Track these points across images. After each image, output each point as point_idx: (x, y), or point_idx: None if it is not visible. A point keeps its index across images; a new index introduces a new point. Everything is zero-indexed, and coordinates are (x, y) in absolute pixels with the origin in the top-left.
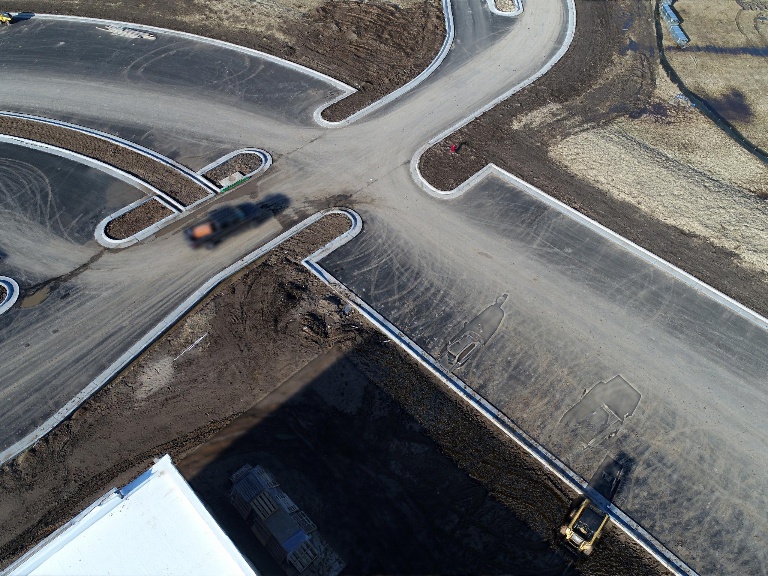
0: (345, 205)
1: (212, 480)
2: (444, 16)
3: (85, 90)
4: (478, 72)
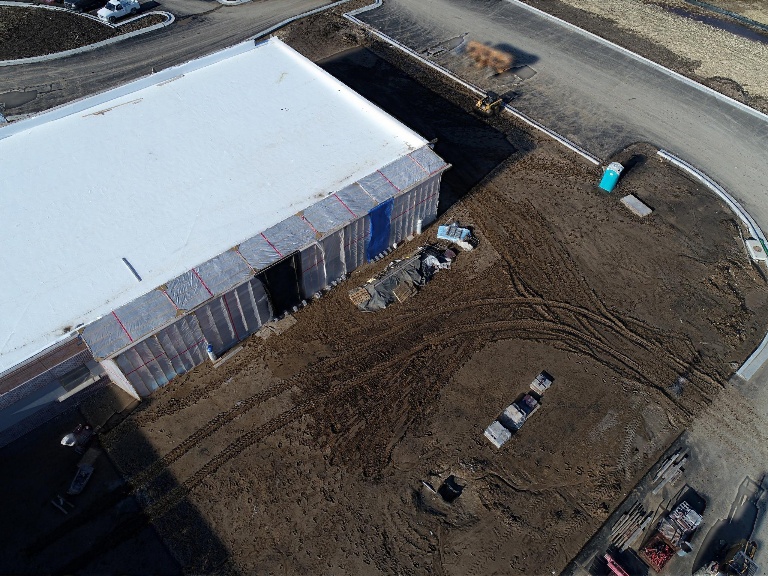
0: None
1: None
2: None
3: None
4: None
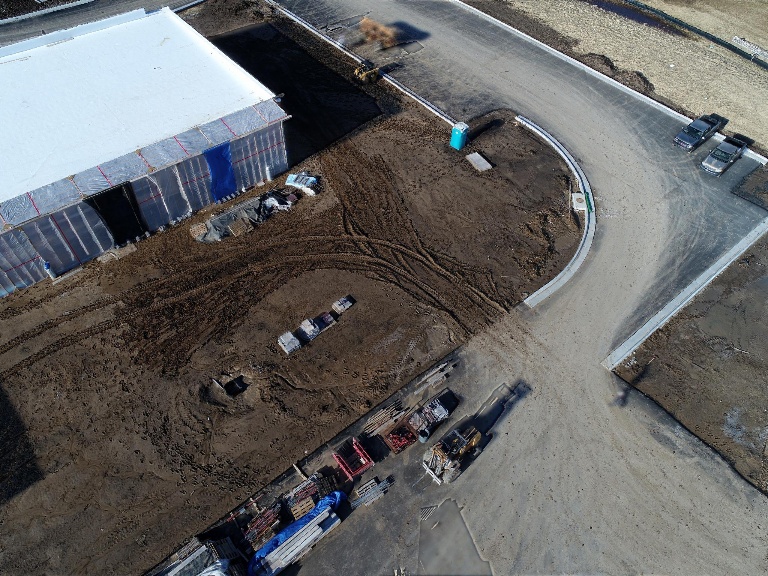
0: None
1: None
2: None
3: None
4: None
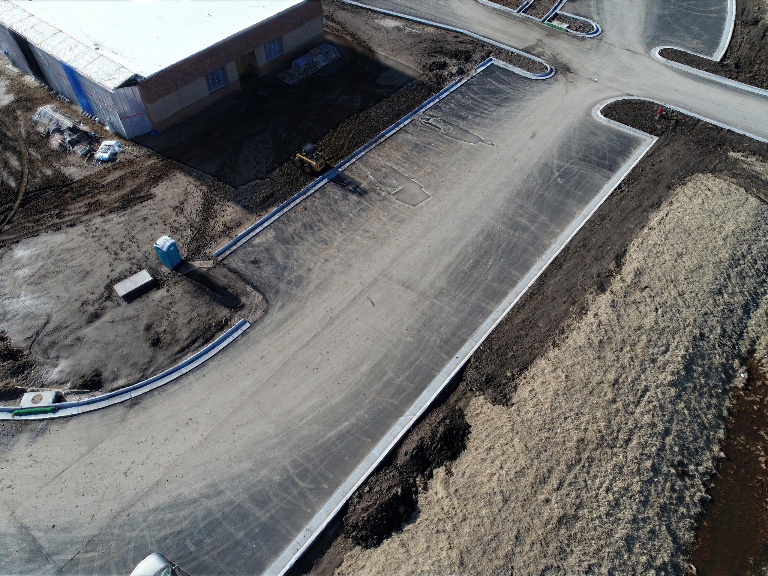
0: (559, 71)
1: (332, 45)
2: None
3: None
4: None
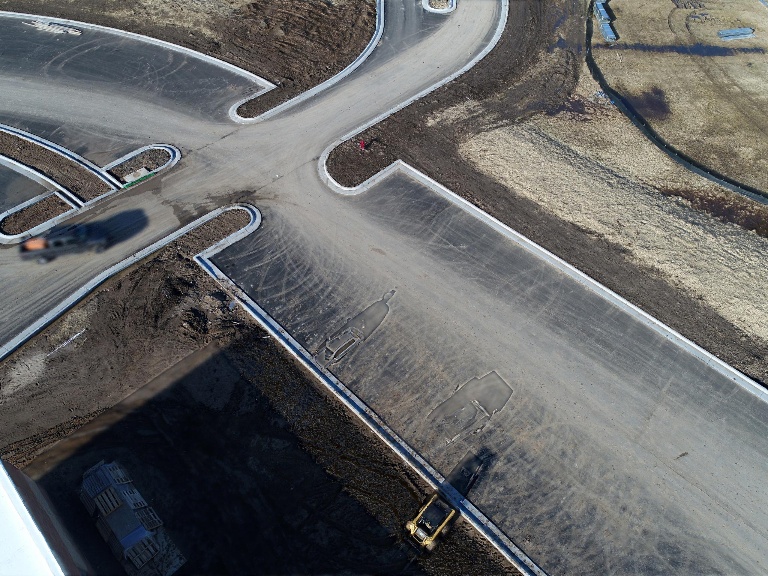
0: (247, 201)
1: (65, 476)
2: (376, 13)
3: (2, 85)
4: (401, 69)
